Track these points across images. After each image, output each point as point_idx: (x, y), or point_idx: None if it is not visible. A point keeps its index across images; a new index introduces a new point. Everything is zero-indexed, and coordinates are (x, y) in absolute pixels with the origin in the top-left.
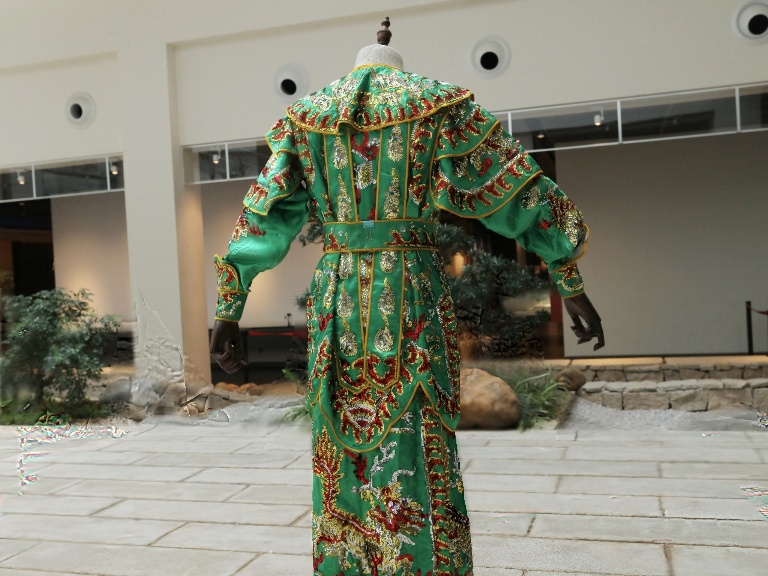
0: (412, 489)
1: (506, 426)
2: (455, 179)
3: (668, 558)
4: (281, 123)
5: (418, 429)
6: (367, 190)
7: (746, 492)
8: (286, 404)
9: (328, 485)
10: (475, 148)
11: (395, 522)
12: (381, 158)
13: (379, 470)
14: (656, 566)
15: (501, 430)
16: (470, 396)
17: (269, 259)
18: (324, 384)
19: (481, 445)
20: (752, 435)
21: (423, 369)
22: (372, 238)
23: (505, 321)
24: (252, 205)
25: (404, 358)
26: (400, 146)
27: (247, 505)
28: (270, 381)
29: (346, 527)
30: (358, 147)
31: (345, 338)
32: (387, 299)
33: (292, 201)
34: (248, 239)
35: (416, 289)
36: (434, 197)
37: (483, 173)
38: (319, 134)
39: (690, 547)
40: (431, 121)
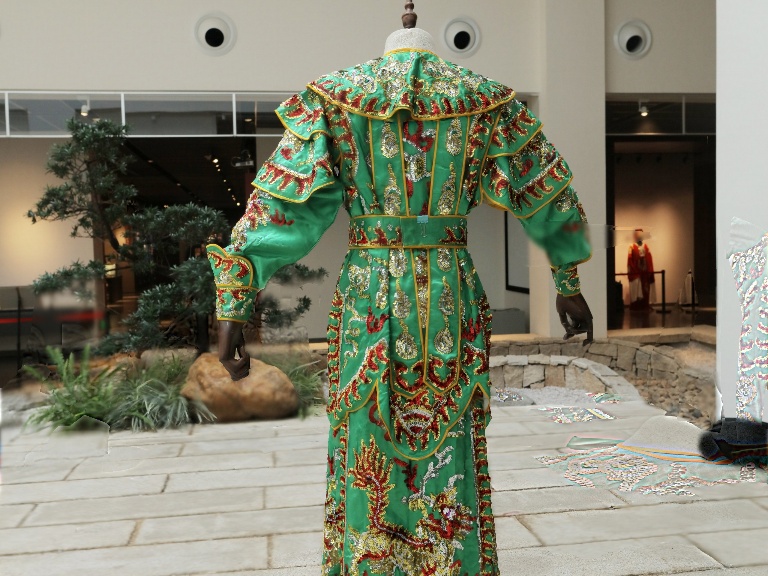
0: (462, 493)
1: (285, 415)
2: (511, 178)
3: (528, 528)
4: (297, 99)
5: (468, 431)
6: (421, 183)
7: (542, 461)
8: (30, 405)
9: (376, 498)
10: (521, 148)
11: (451, 529)
12: (437, 150)
13: (434, 477)
14: (526, 537)
15: (280, 419)
16: (249, 387)
17: (299, 252)
18: (385, 390)
19: (272, 436)
20: (507, 410)
21: (483, 370)
22: (427, 234)
23: (271, 309)
24: (275, 190)
25: (461, 360)
26: (459, 140)
27: (54, 527)
28: (7, 380)
29: (394, 540)
30: (411, 136)
31: (404, 340)
32: (447, 299)
33: (324, 188)
34: (268, 228)
35: (471, 288)
36: (488, 195)
37: (525, 174)
38: (365, 118)
39: (538, 516)
40: (488, 117)
